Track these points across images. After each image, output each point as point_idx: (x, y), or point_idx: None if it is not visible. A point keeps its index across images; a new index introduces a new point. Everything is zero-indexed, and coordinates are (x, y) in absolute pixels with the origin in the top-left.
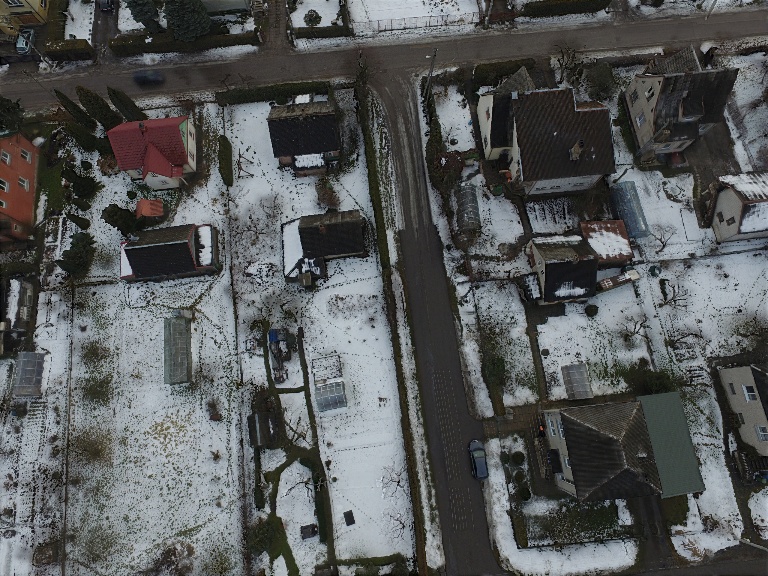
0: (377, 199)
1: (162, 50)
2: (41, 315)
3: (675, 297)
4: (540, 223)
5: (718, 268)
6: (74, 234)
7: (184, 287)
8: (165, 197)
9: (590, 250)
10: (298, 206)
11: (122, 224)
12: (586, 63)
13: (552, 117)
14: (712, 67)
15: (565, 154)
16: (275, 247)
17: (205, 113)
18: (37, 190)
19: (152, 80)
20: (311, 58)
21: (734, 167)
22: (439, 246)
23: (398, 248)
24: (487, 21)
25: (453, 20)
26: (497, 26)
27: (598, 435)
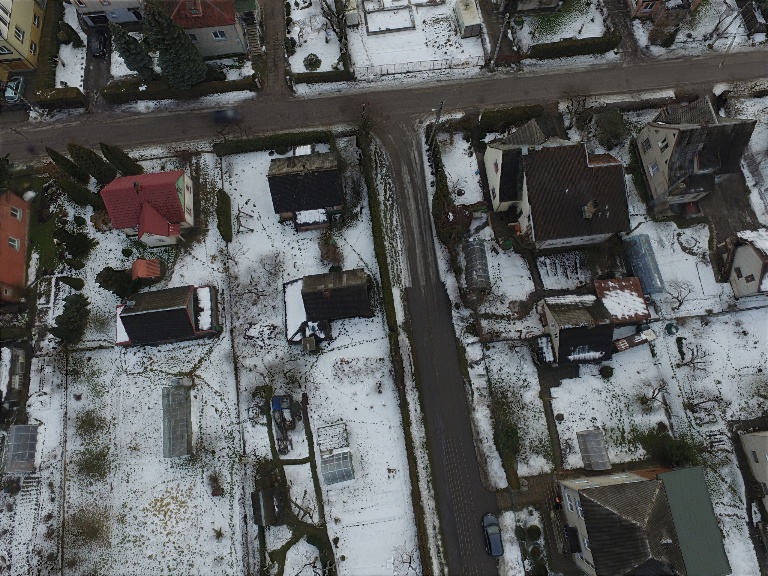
0: (382, 257)
1: (157, 97)
2: (34, 383)
3: (694, 359)
4: (551, 278)
5: (736, 325)
6: (67, 296)
7: (183, 351)
8: (162, 254)
9: (605, 313)
10: (300, 263)
11: (117, 288)
12: (595, 107)
13: (564, 173)
14: (725, 110)
15: (578, 212)
16: (277, 307)
17: (202, 164)
18: (28, 248)
19: (147, 129)
20: (311, 104)
21: (750, 217)
22: (447, 305)
23: (405, 307)
24: (493, 64)
25: (457, 63)
26: (503, 69)
27: (620, 520)
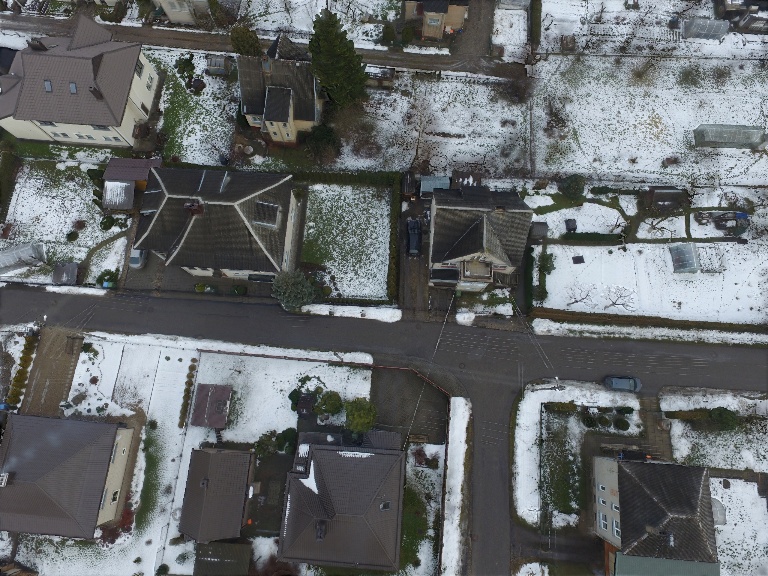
0: None
1: None
2: (753, 37)
3: None
4: None
5: None
6: None
7: None
8: None
9: None
10: None
11: None
12: None
13: None
14: None
15: None
16: None
17: None
18: None
19: None
20: None
21: None
22: None
23: None
24: None
25: None
26: None
27: (695, 498)
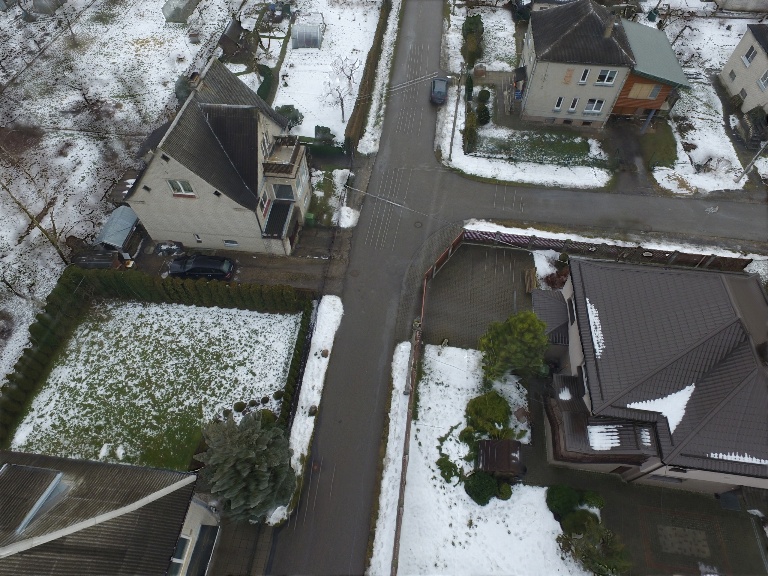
0: None
1: None
2: None
3: (670, 14)
4: None
5: None
6: None
7: None
8: None
9: None
10: None
11: None
12: None
13: None
14: None
15: None
16: None
17: None
18: None
19: None
20: None
21: None
22: None
23: None
24: None
25: None
26: None
27: (566, 6)
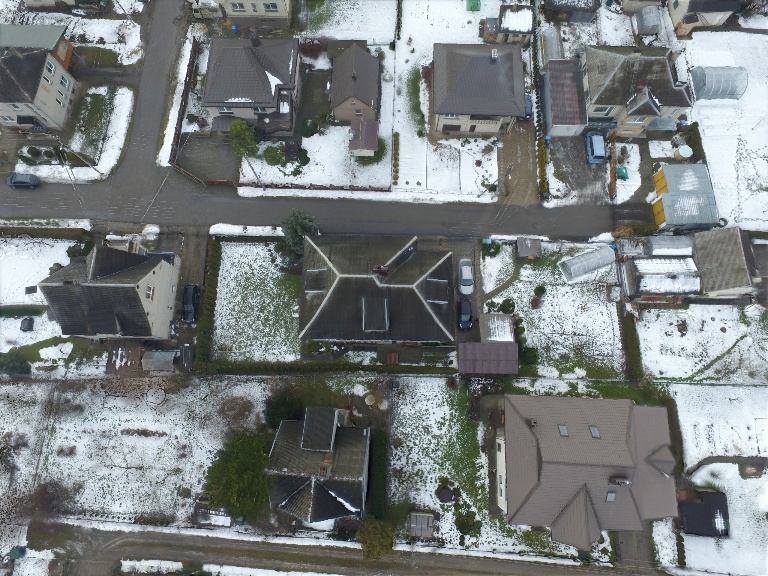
0: None
1: None
2: None
3: None
4: None
5: None
6: None
7: None
8: None
9: None
10: None
11: None
12: None
13: None
14: None
15: None
16: None
17: None
18: None
19: None
20: None
21: None
22: None
23: None
24: None
25: None
26: None
27: None
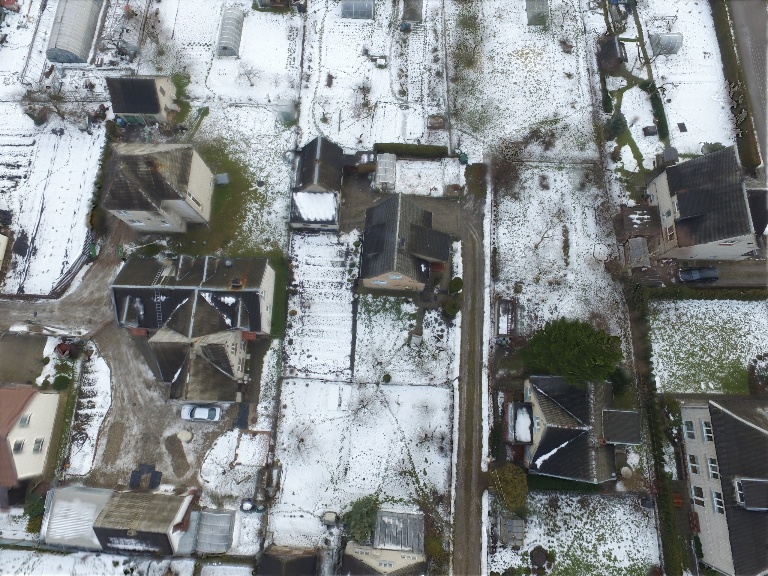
0: None
1: None
2: None
3: None
4: None
5: None
6: None
7: None
8: None
9: None
10: None
11: None
12: None
13: None
14: None
15: None
16: None
17: None
18: None
19: None
20: None
21: None
22: None
23: None
24: None
25: None
26: None
27: None
